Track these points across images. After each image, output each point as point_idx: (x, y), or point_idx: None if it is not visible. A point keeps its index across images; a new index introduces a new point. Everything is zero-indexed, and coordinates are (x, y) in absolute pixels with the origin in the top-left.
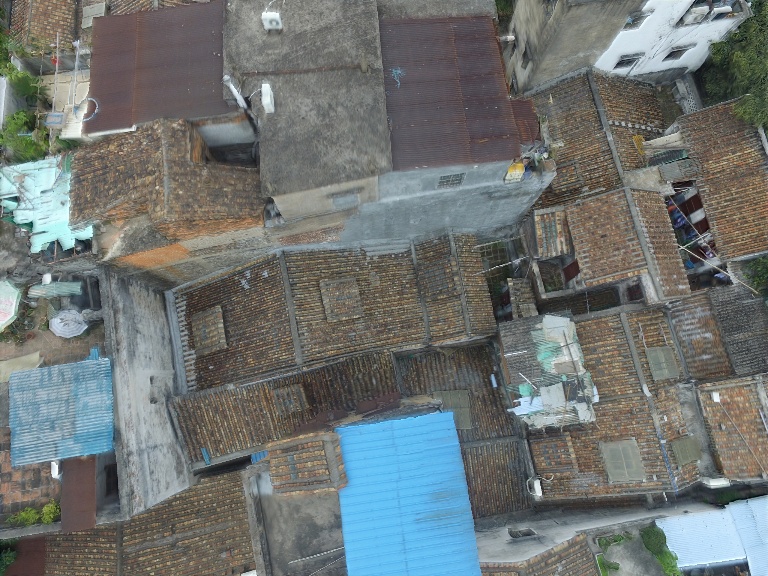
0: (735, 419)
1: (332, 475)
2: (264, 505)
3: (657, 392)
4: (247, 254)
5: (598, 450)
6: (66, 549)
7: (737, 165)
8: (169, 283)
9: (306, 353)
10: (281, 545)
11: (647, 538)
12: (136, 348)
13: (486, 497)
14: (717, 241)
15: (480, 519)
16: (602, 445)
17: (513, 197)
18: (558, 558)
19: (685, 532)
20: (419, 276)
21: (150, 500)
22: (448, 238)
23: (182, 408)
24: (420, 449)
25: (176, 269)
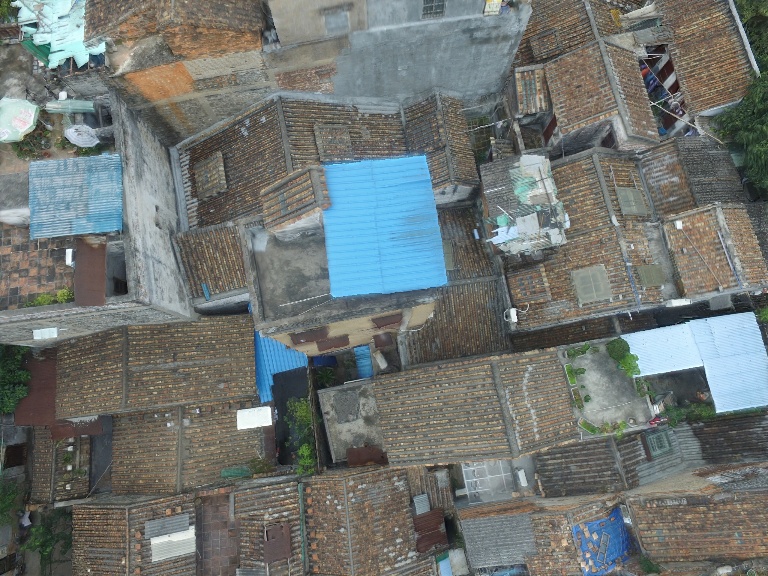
0: (696, 243)
1: (317, 196)
2: (257, 259)
3: (625, 224)
4: (247, 97)
5: (570, 280)
6: (75, 377)
7: (706, 28)
8: (174, 134)
9: None
10: (272, 292)
11: (612, 347)
12: (143, 174)
13: (467, 336)
14: (686, 98)
15: (461, 359)
16: (573, 272)
17: (494, 42)
18: (529, 361)
19: (648, 346)
20: (407, 133)
21: (154, 299)
22: (435, 98)
23: (185, 243)
24: (396, 183)
25: (181, 110)
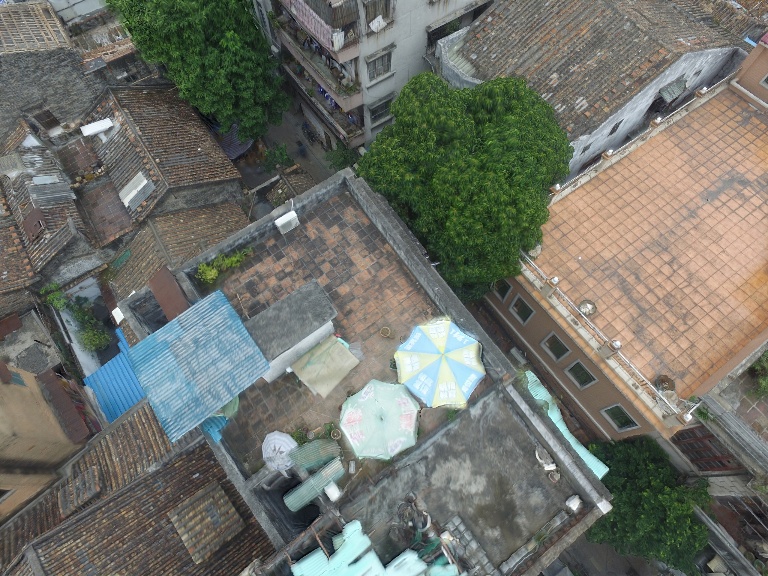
0: None
1: None
2: None
3: None
4: None
5: None
6: None
7: None
8: None
9: (29, 569)
10: None
11: None
12: None
13: None
14: None
15: None
16: None
17: None
18: None
19: None
20: None
21: None
22: None
23: None
24: None
25: None
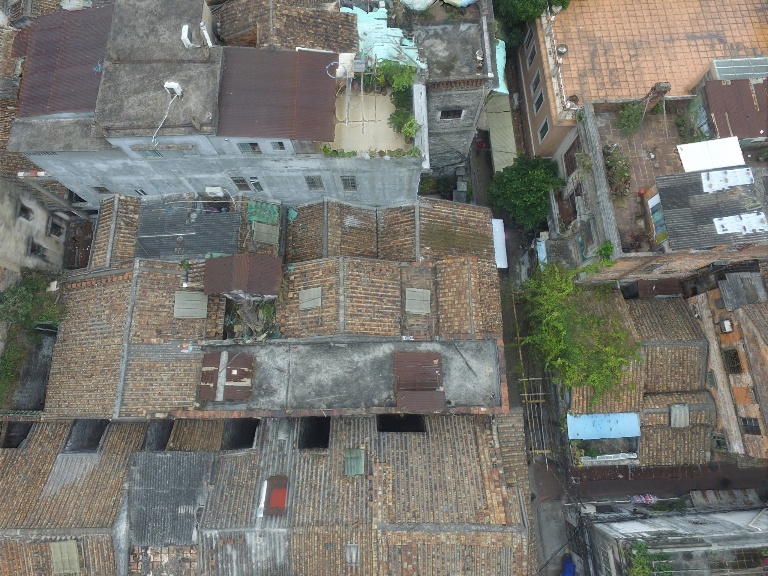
0: None
1: None
2: None
3: None
4: None
5: None
6: None
7: None
8: None
9: None
10: None
11: None
12: None
13: None
14: None
15: None
16: None
17: None
18: None
19: None
20: None
21: None
22: None
23: None
24: None
25: None
